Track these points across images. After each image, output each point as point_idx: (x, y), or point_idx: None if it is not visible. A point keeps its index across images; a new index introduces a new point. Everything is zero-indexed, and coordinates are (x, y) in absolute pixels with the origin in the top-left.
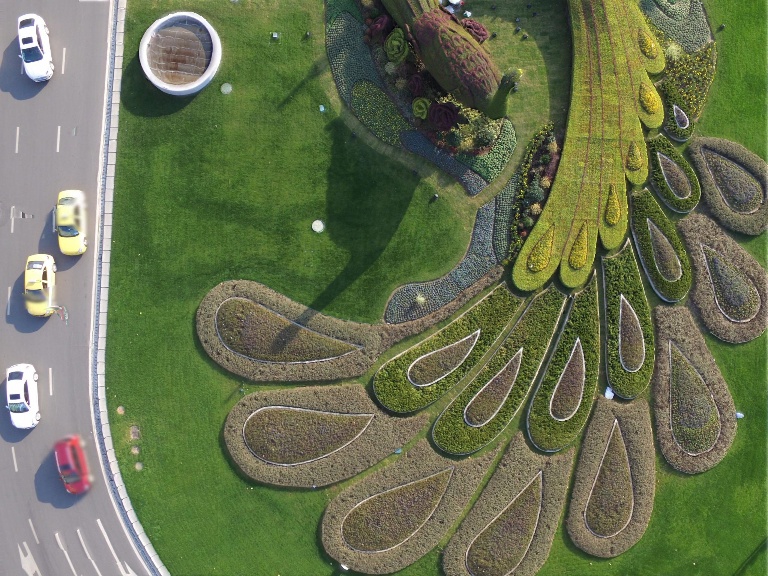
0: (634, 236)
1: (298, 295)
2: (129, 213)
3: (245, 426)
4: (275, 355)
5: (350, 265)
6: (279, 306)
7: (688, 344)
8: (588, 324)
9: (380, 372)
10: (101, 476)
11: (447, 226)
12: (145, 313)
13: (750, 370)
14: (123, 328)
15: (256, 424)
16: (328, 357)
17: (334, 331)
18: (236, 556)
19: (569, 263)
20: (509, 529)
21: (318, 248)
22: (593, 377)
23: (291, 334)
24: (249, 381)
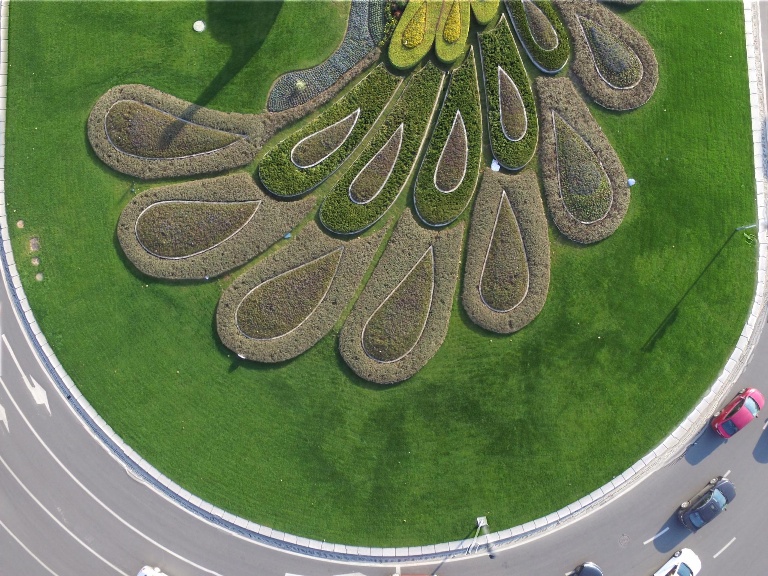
0: (508, 11)
1: (183, 93)
2: (23, 36)
3: (137, 223)
4: (162, 151)
5: (231, 60)
6: (164, 104)
7: (571, 112)
8: (467, 96)
9: (264, 158)
10: (4, 291)
11: (323, 15)
12: (40, 128)
13: (639, 137)
14: (20, 145)
15: (147, 220)
16: (214, 149)
17: (218, 122)
18: (135, 356)
19: (443, 37)
20: (402, 306)
21: (200, 47)
22: (476, 148)
23: (176, 128)
24: (140, 180)
